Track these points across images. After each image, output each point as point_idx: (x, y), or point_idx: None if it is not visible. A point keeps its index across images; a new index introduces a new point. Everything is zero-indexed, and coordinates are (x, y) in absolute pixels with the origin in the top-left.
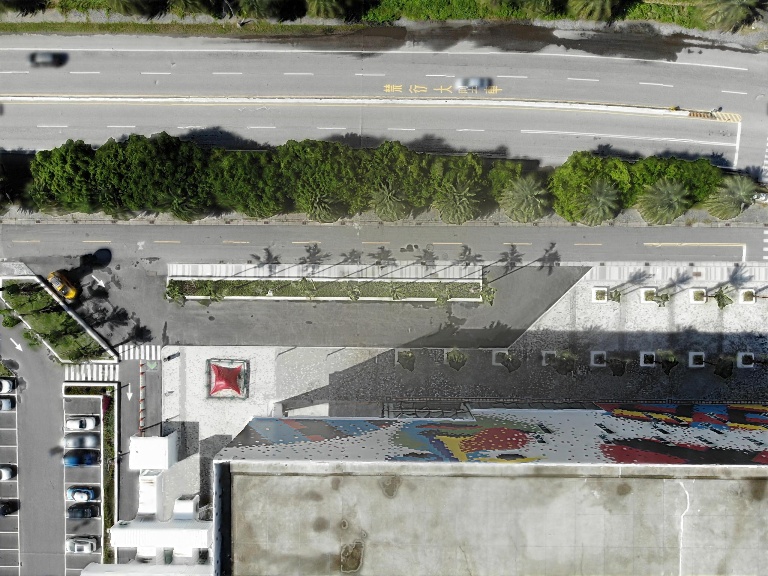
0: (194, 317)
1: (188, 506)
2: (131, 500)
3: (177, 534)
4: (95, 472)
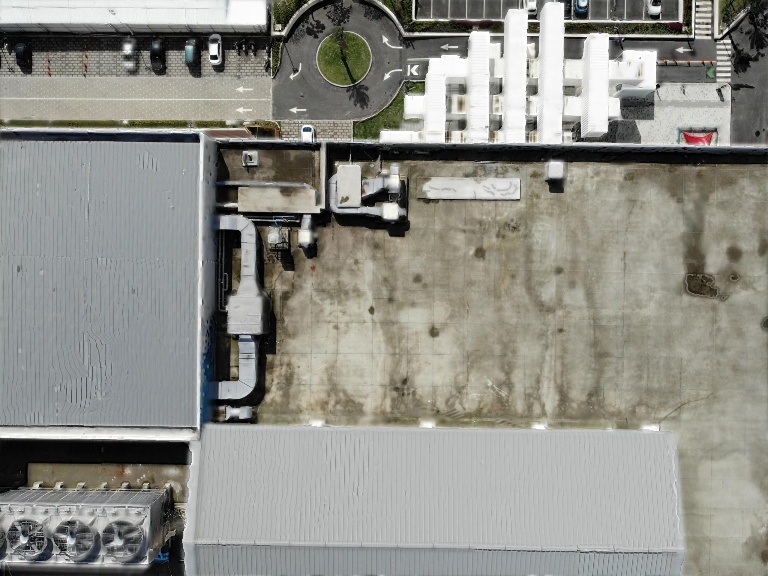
0: (759, 115)
1: (616, 111)
2: (575, 50)
3: (603, 101)
4: (602, 14)
